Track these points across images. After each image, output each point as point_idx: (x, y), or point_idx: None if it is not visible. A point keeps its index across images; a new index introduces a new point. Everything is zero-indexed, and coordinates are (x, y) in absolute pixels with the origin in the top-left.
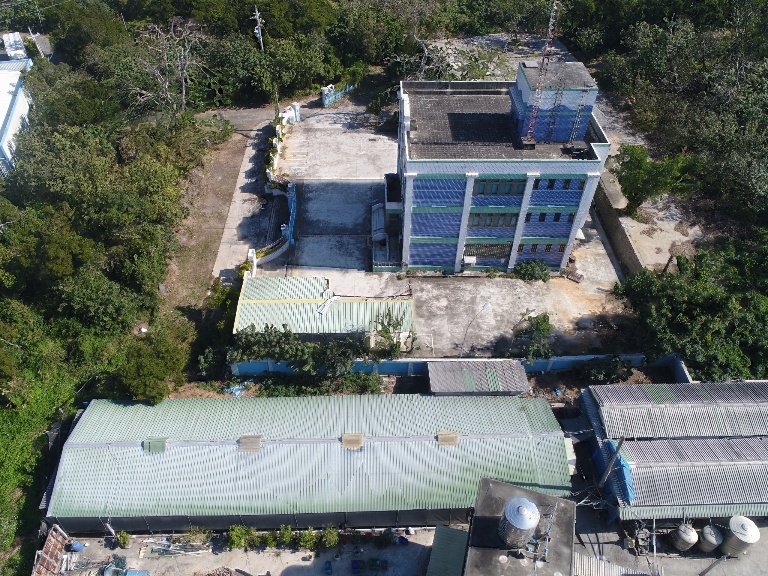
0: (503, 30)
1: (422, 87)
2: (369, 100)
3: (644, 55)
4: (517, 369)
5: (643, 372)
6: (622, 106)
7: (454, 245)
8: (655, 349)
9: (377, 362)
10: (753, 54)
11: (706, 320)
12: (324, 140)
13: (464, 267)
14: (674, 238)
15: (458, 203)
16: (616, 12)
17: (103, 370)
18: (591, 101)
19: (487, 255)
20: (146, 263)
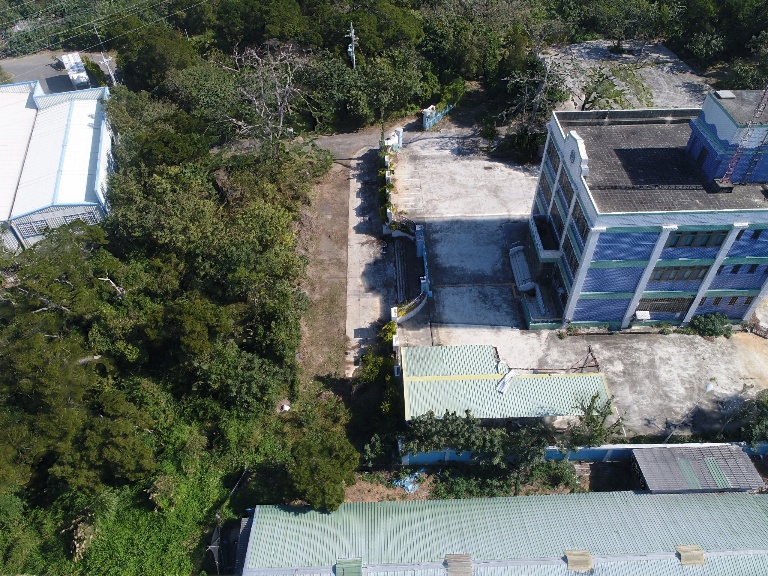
0: (601, 36)
1: (576, 118)
2: (472, 121)
3: None
4: (740, 457)
5: None
6: None
7: (627, 300)
8: None
9: (573, 450)
10: None
11: None
12: (435, 170)
13: (633, 322)
14: None
15: (643, 257)
16: (734, 15)
17: (251, 460)
18: None
19: (662, 309)
20: (284, 330)
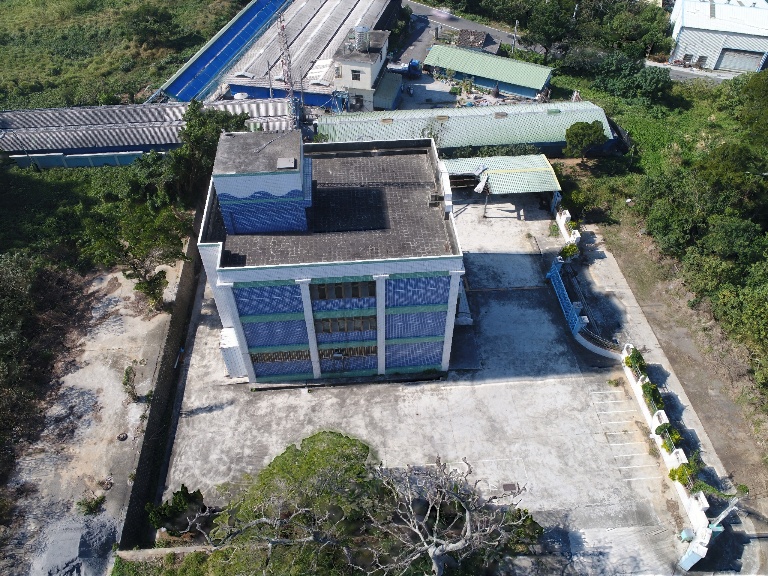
0: None
1: (429, 263)
2: None
3: None
4: None
5: None
6: None
7: None
8: None
9: None
10: None
11: None
12: (597, 481)
13: None
14: None
15: None
16: None
17: None
18: None
19: None
20: None
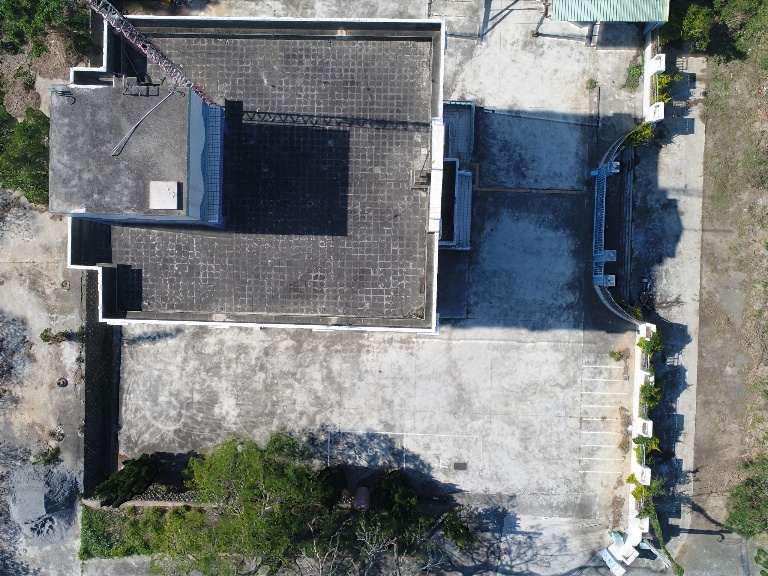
0: None
1: None
2: None
3: None
4: None
5: None
6: None
7: None
8: None
9: None
10: None
11: None
12: (551, 471)
13: None
14: None
15: None
16: None
17: None
18: None
19: None
20: None
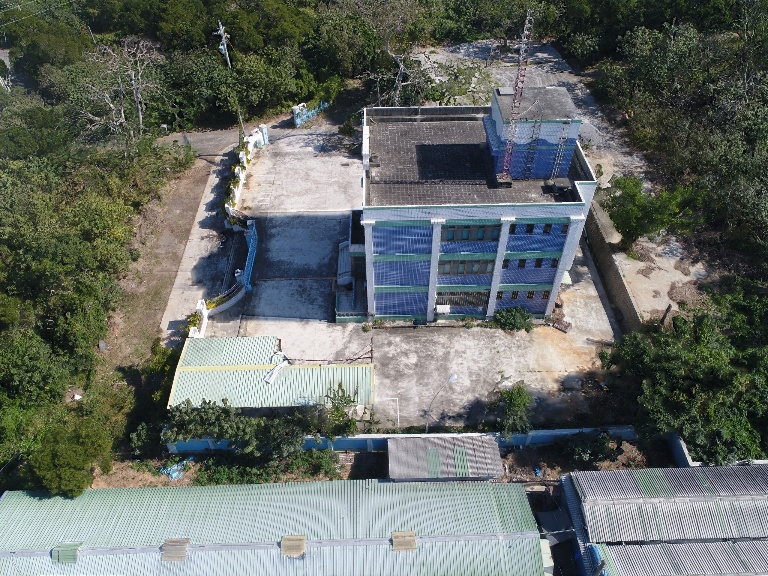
0: (492, 36)
1: (389, 114)
2: (345, 118)
3: (643, 64)
4: (490, 447)
5: (636, 446)
6: (619, 121)
7: (424, 293)
8: (648, 427)
9: (331, 439)
10: (763, 62)
11: (706, 398)
12: (293, 166)
13: (437, 316)
14: (674, 278)
15: (425, 250)
16: (613, 15)
17: (28, 447)
18: (574, 134)
19: (462, 303)
20: (80, 321)
